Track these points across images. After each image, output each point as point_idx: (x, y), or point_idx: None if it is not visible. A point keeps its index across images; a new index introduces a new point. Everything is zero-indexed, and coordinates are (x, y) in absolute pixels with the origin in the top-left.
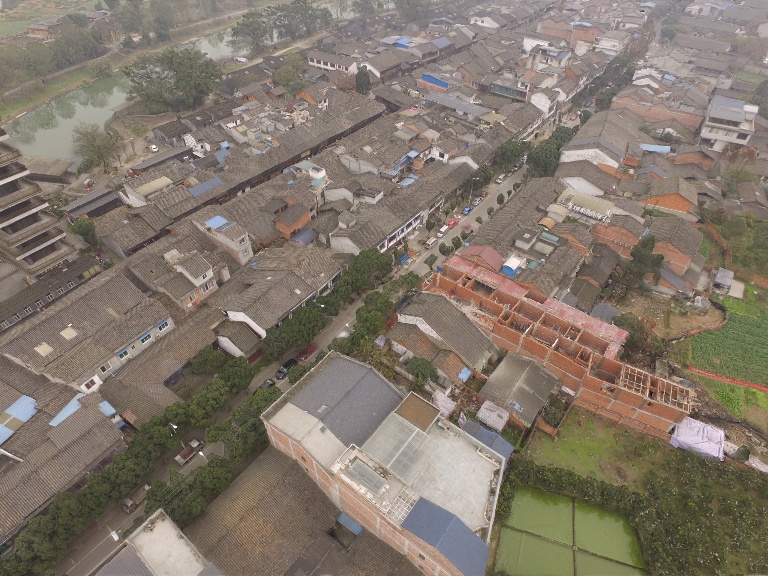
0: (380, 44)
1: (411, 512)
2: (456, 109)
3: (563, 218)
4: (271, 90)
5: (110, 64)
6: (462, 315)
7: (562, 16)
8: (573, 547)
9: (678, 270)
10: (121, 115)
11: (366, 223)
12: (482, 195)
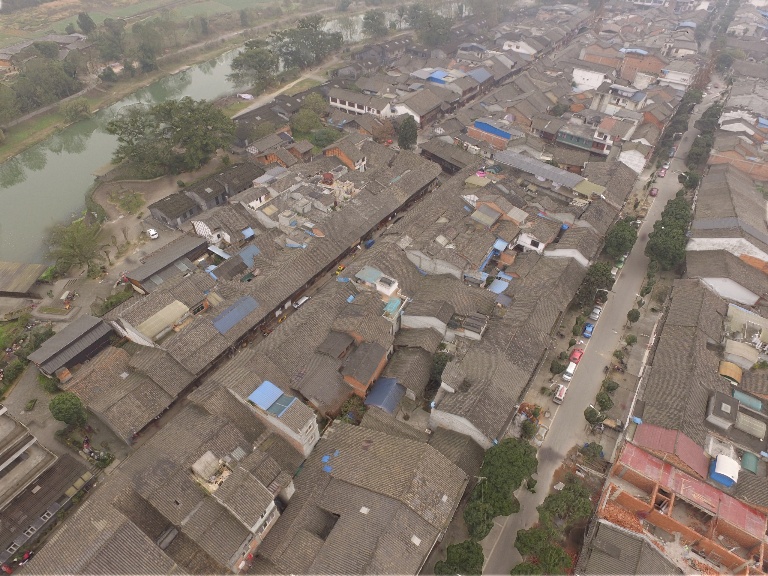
0: (411, 78)
1: None
2: (535, 174)
3: (752, 363)
4: (295, 146)
5: (87, 105)
6: (678, 573)
7: (600, 38)
8: None
9: None
10: (105, 180)
11: (486, 388)
12: (599, 303)
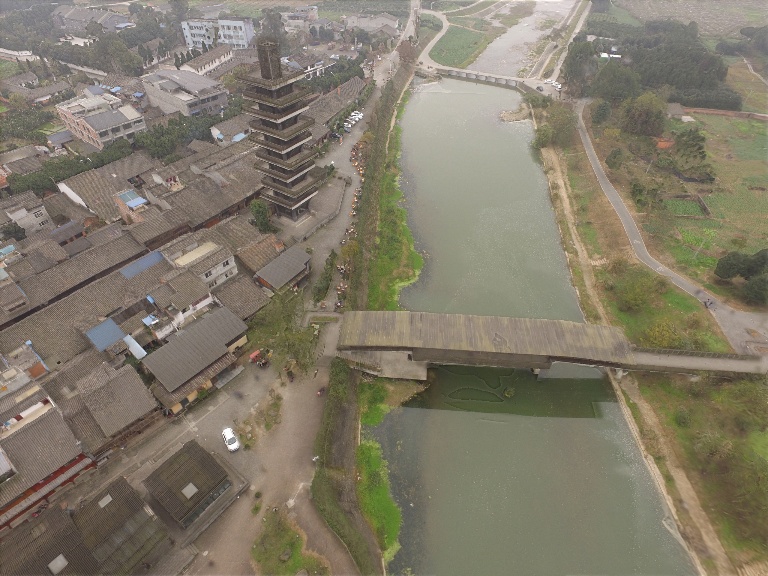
0: None
1: None
2: None
3: None
4: None
5: None
6: None
7: None
8: None
9: None
10: None
11: (3, 200)
12: None
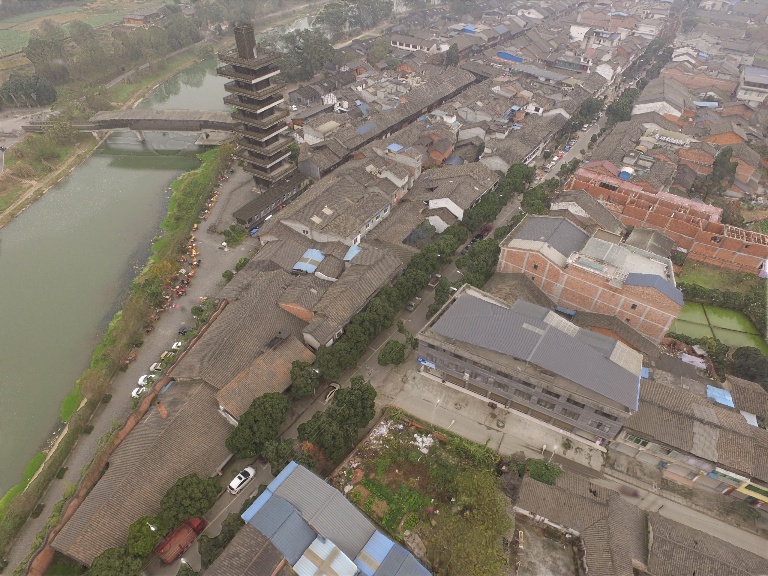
0: (449, 30)
1: (627, 278)
2: (539, 76)
3: (653, 145)
4: (376, 64)
5: (213, 47)
6: (598, 203)
7: None
8: (710, 325)
9: (744, 179)
10: None
11: (508, 148)
12: (575, 138)
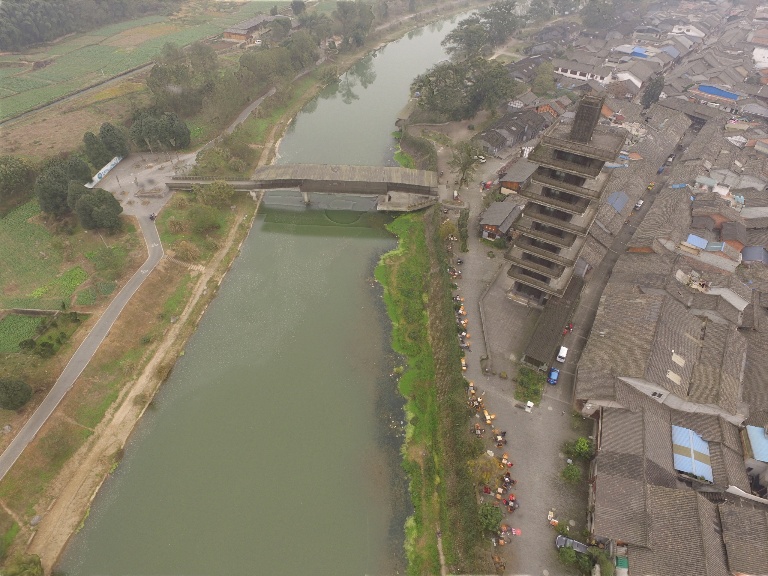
0: (613, 53)
1: None
2: None
3: None
4: (560, 100)
5: None
6: None
7: (755, 25)
8: None
9: None
10: None
11: None
12: None
